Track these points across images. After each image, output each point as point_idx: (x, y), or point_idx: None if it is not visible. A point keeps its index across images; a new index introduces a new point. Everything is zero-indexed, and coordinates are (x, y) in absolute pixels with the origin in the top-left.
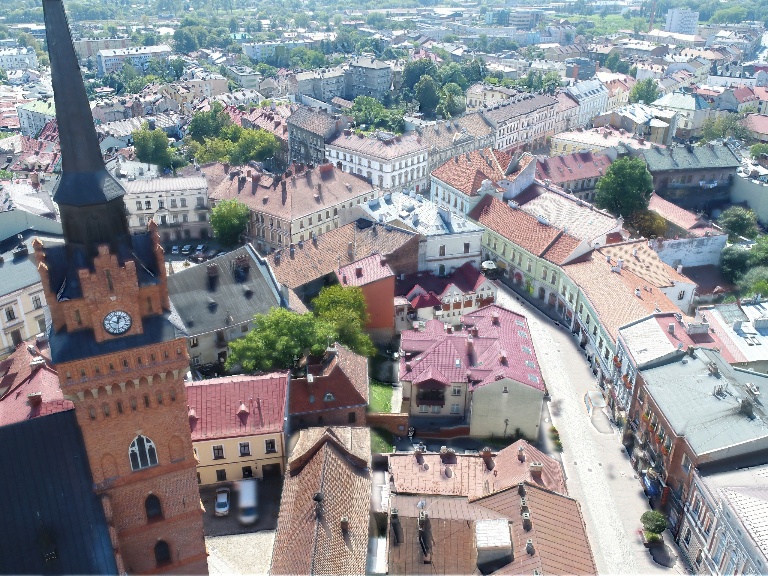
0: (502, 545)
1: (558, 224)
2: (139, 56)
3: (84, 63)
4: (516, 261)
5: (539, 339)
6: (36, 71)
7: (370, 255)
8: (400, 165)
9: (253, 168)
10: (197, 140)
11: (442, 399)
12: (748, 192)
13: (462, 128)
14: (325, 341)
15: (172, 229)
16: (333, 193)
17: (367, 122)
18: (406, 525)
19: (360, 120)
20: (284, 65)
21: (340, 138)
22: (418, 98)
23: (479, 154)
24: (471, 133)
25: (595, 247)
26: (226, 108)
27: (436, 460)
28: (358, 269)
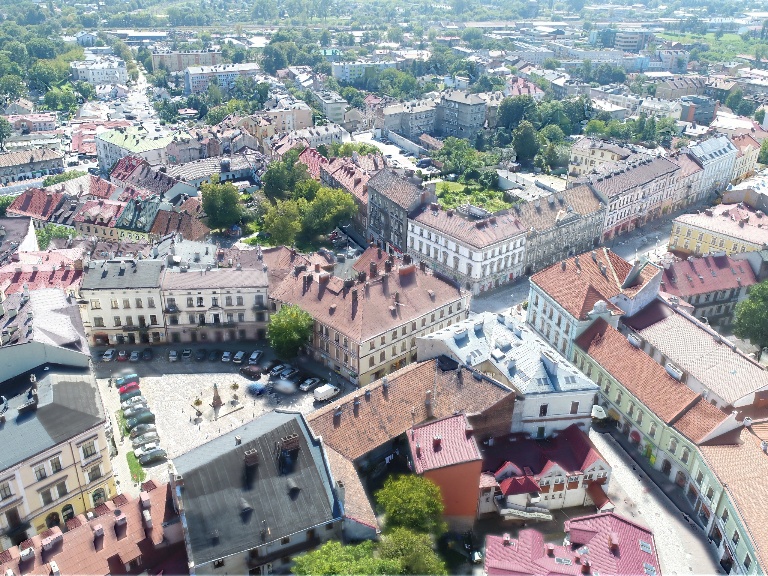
0: None
1: (689, 367)
2: (226, 74)
3: (172, 79)
4: (634, 417)
5: (664, 544)
6: (125, 86)
7: (452, 416)
8: (493, 252)
9: (323, 257)
10: (270, 194)
11: None
12: None
13: (568, 205)
14: None
15: (225, 329)
16: (412, 303)
17: (456, 171)
18: None
19: (449, 168)
20: (373, 88)
21: (425, 213)
22: (515, 146)
23: (591, 257)
24: (577, 210)
25: (745, 423)
26: (306, 150)
27: None
28: (436, 440)
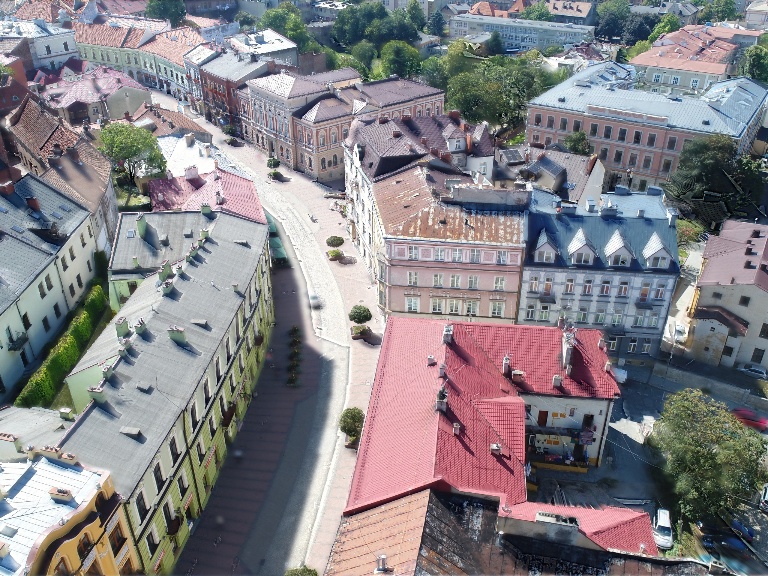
0: (150, 123)
1: None
2: None
3: None
4: (105, 59)
5: None
6: None
7: None
8: None
9: None
10: None
11: (88, 117)
12: (250, 9)
13: None
14: None
15: None
16: None
17: None
18: (95, 133)
19: None
20: None
21: None
22: None
23: None
24: None
25: (156, 33)
26: None
27: (98, 125)
28: None
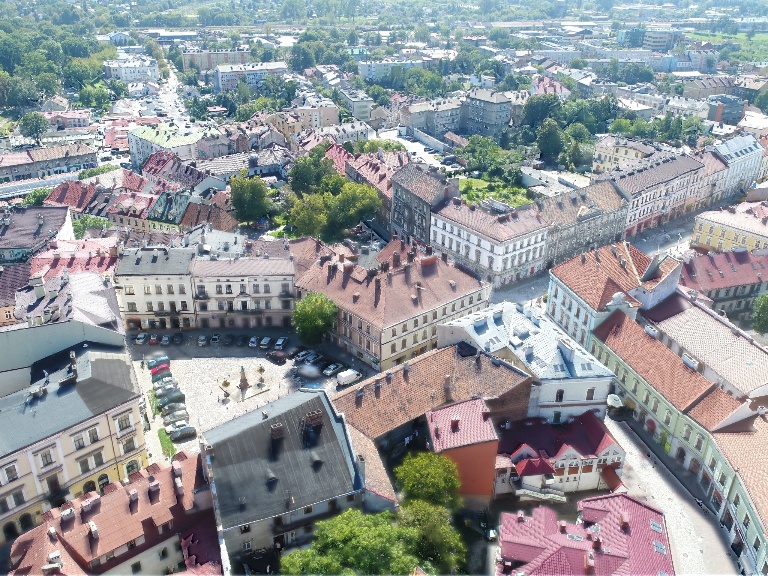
0: None
1: (706, 358)
2: (255, 72)
3: (202, 77)
4: (650, 406)
5: (676, 528)
6: (156, 84)
7: (470, 399)
8: (514, 246)
9: (347, 248)
10: (296, 188)
11: None
12: None
13: (590, 201)
14: (401, 574)
15: (252, 316)
16: (434, 293)
17: (480, 168)
18: None
19: (473, 165)
20: (399, 87)
21: (448, 207)
22: (539, 144)
23: (610, 251)
24: (599, 206)
25: (759, 412)
26: (332, 147)
27: None
28: (454, 421)
